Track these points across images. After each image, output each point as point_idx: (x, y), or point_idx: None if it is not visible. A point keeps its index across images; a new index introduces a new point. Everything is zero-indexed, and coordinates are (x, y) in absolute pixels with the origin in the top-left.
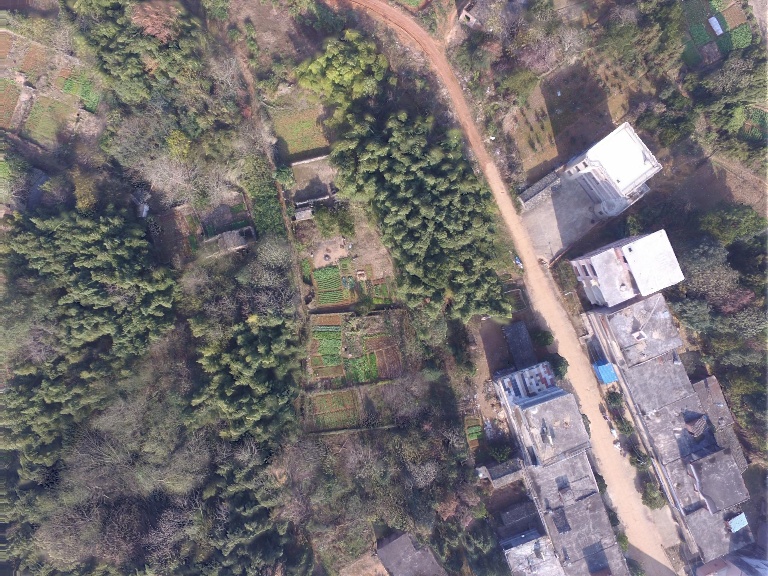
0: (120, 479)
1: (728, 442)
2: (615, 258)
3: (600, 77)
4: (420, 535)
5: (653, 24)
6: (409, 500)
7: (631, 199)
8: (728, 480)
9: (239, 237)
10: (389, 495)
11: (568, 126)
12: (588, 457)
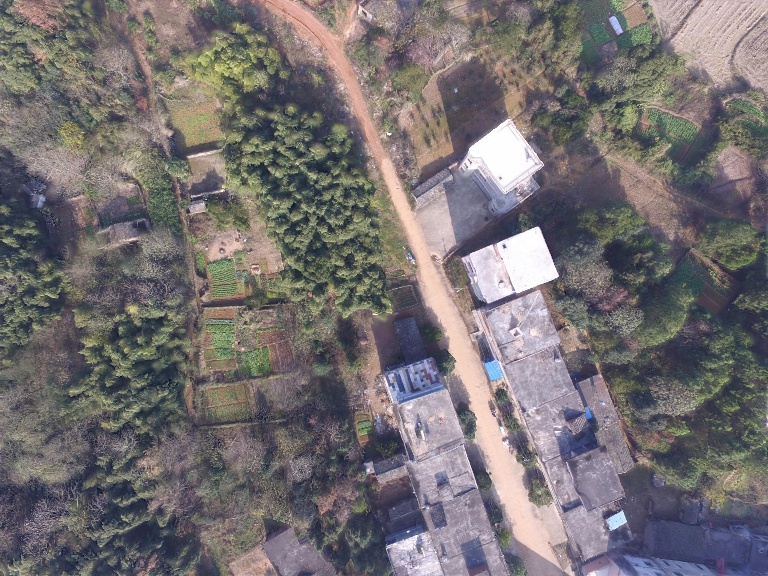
0: (2, 469)
1: (613, 440)
2: (494, 255)
3: (497, 74)
4: (297, 529)
5: None
6: (289, 494)
7: (521, 197)
8: (603, 478)
9: (132, 229)
10: (273, 489)
11: (464, 123)
12: (477, 454)
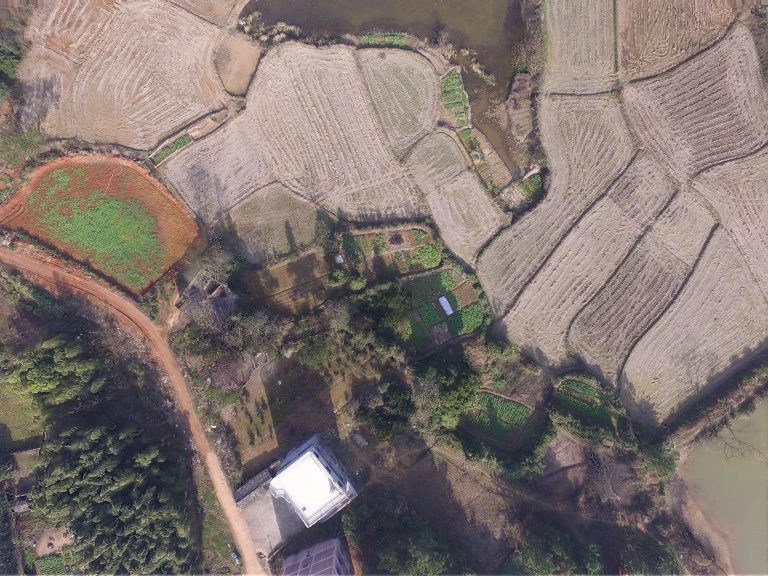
0: None
1: None
2: None
3: (322, 365)
4: None
5: (367, 320)
6: None
7: (340, 503)
8: None
9: None
10: None
11: (289, 416)
12: None
